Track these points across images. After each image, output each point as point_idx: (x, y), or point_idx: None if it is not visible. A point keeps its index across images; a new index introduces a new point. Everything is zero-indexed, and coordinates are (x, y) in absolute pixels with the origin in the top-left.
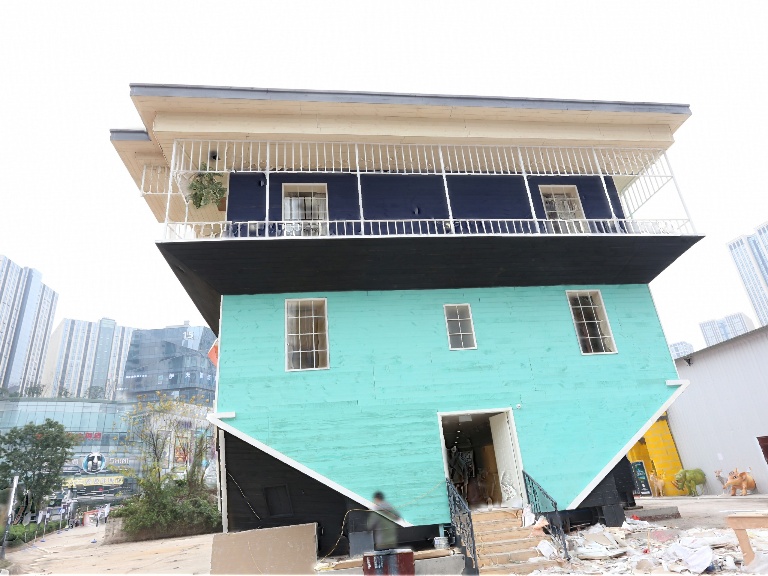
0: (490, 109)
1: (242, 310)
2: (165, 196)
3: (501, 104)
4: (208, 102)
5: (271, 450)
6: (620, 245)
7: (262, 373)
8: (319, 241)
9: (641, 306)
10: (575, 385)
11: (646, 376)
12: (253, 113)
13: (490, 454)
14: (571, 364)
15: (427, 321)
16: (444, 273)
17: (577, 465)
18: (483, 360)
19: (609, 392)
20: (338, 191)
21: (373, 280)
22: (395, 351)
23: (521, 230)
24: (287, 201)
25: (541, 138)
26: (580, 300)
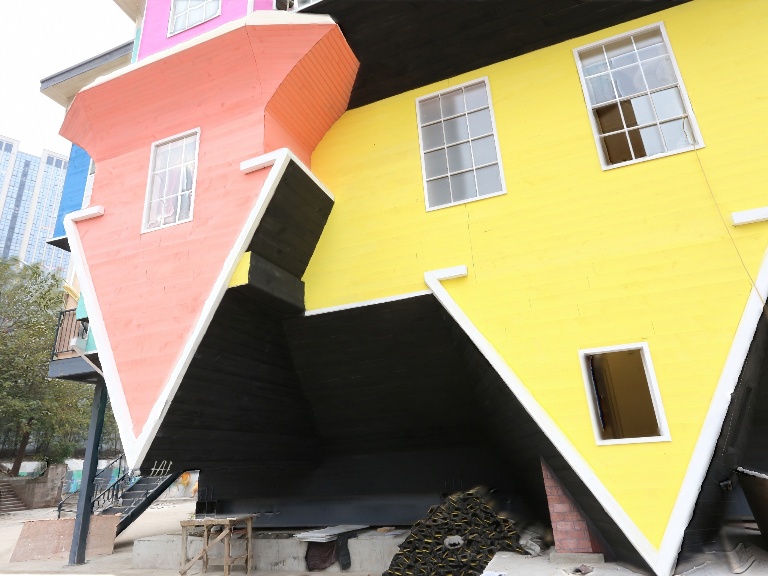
0: None
1: None
2: None
3: None
4: None
5: None
6: None
7: None
8: None
9: None
10: None
11: None
12: None
13: None
14: None
15: None
16: None
17: None
18: None
19: None
20: None
21: None
22: None
23: None
24: None
25: None
26: None
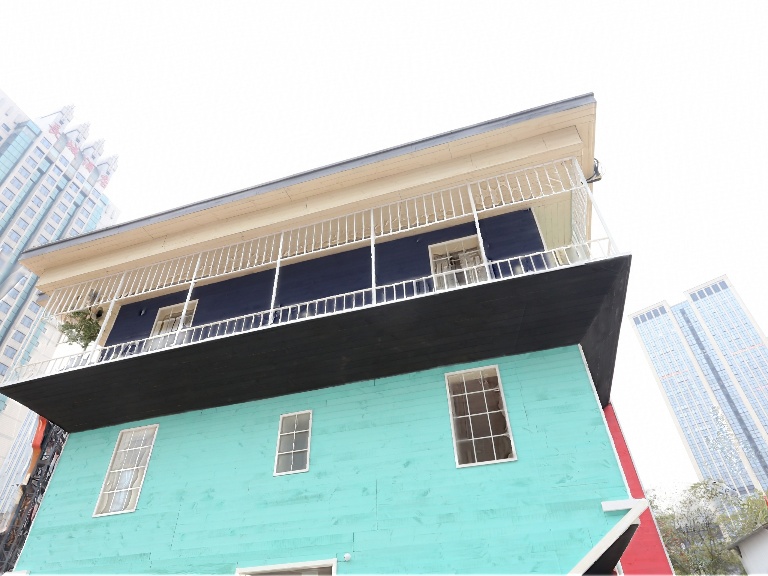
0: (326, 179)
1: (80, 448)
2: None
3: (337, 170)
4: (74, 250)
5: None
6: (494, 296)
7: (71, 520)
8: (129, 361)
9: (565, 380)
10: (439, 518)
11: (565, 496)
12: (115, 249)
13: None
14: (438, 484)
15: (256, 439)
16: (277, 375)
17: None
18: (312, 487)
19: (495, 528)
20: (207, 304)
21: (202, 396)
22: (210, 483)
23: (352, 305)
24: (159, 325)
25: (392, 192)
26: (469, 384)
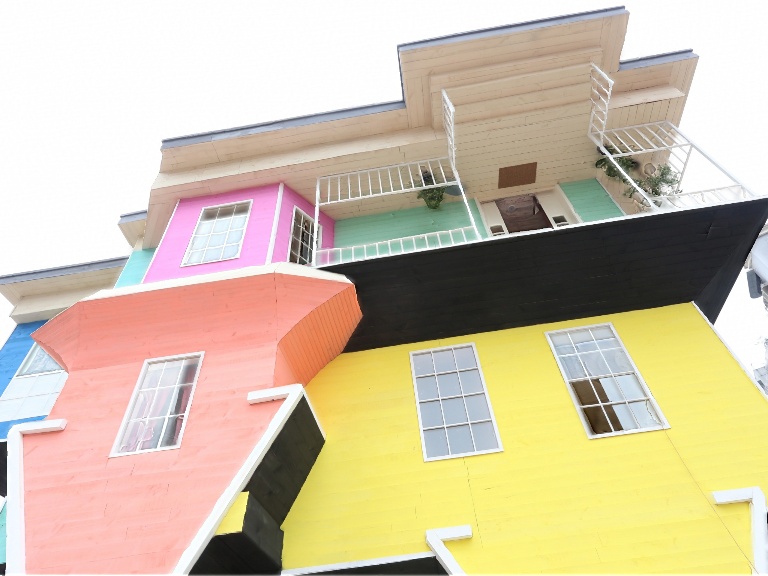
0: None
1: None
2: (522, 87)
3: None
4: None
5: None
6: None
7: None
8: None
9: None
10: None
11: None
12: None
13: None
14: None
15: None
16: None
17: None
18: None
19: None
20: None
21: None
22: None
23: None
24: None
25: None
26: None
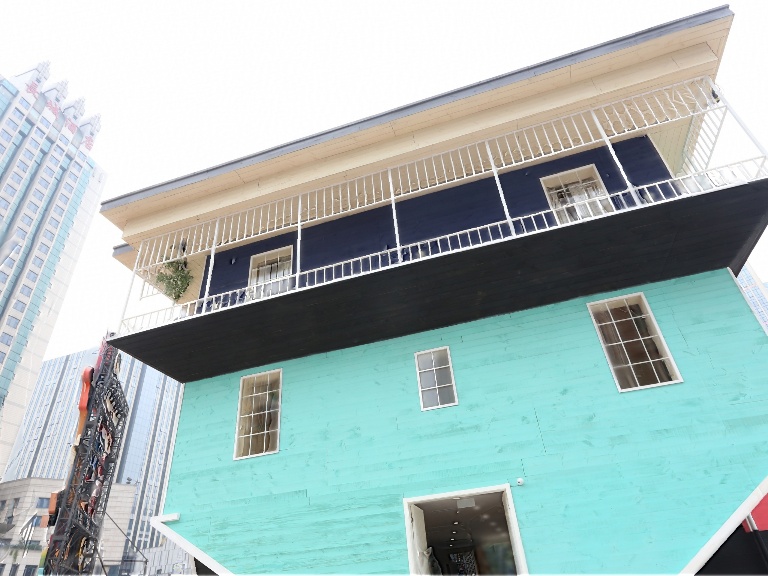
0: (435, 110)
1: (200, 396)
2: None
3: (447, 100)
4: (160, 198)
5: (206, 559)
6: (646, 222)
7: (210, 465)
8: (251, 307)
9: (719, 303)
10: (611, 440)
11: (742, 412)
12: (203, 196)
13: (503, 555)
14: (602, 409)
15: (394, 377)
16: (407, 314)
17: (623, 574)
18: (467, 419)
19: (673, 446)
20: (303, 249)
21: (327, 338)
22: (353, 421)
23: (489, 238)
24: (255, 273)
25: (510, 121)
26: (613, 313)
